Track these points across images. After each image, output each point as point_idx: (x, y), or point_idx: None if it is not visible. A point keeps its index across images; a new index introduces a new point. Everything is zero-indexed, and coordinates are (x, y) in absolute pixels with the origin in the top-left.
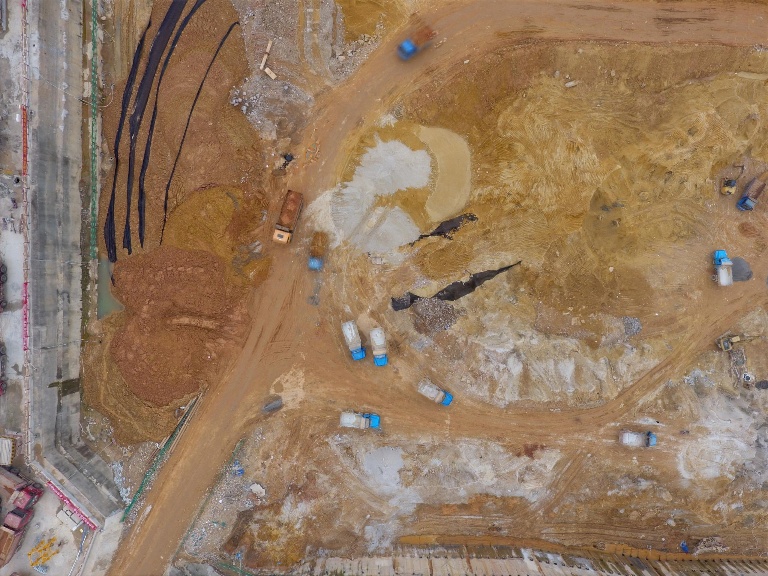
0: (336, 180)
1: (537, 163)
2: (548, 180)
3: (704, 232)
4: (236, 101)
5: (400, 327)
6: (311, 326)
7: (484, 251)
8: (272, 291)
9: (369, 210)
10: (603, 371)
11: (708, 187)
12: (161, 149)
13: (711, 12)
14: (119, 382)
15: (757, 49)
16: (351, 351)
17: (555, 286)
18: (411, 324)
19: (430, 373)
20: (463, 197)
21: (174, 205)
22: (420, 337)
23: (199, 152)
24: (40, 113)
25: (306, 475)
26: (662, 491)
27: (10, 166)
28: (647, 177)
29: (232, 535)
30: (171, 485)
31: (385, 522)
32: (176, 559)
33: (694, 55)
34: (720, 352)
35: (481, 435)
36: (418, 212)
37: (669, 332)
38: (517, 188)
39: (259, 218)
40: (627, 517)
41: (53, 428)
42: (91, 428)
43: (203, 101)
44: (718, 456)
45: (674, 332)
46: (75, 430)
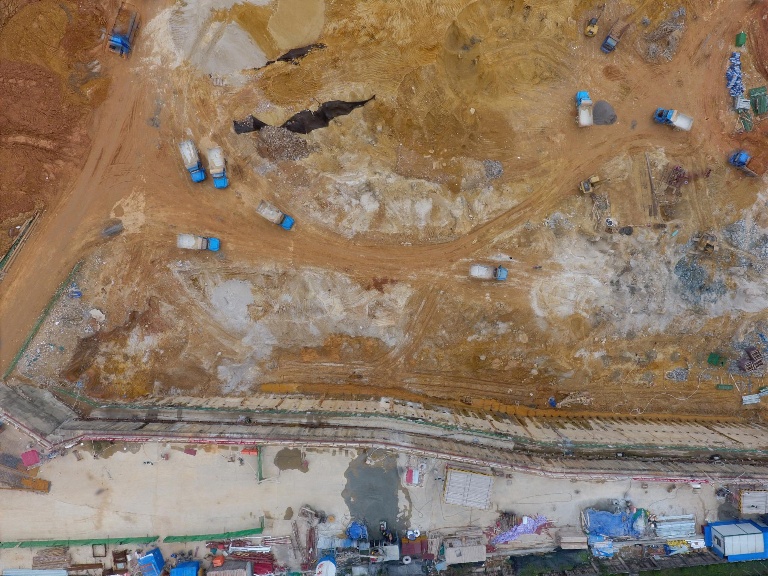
0: None
1: None
2: (403, 13)
3: (568, 75)
4: None
5: (243, 151)
6: (152, 148)
7: (333, 80)
8: (112, 112)
9: (206, 25)
10: (459, 210)
11: (571, 28)
12: None
13: None
14: None
15: None
16: (188, 170)
17: (415, 127)
18: (254, 148)
19: (273, 198)
20: (315, 28)
21: (6, 16)
22: (263, 162)
23: None
24: None
25: (148, 302)
26: (520, 333)
27: None
28: (507, 14)
29: (76, 366)
30: (5, 305)
31: (239, 363)
32: (9, 378)
33: None
34: (583, 197)
35: (327, 265)
36: (260, 33)
37: (531, 176)
38: (371, 21)
39: (97, 36)
40: (490, 366)
41: None
42: None
43: None
44: (572, 293)
45: (537, 176)
46: None
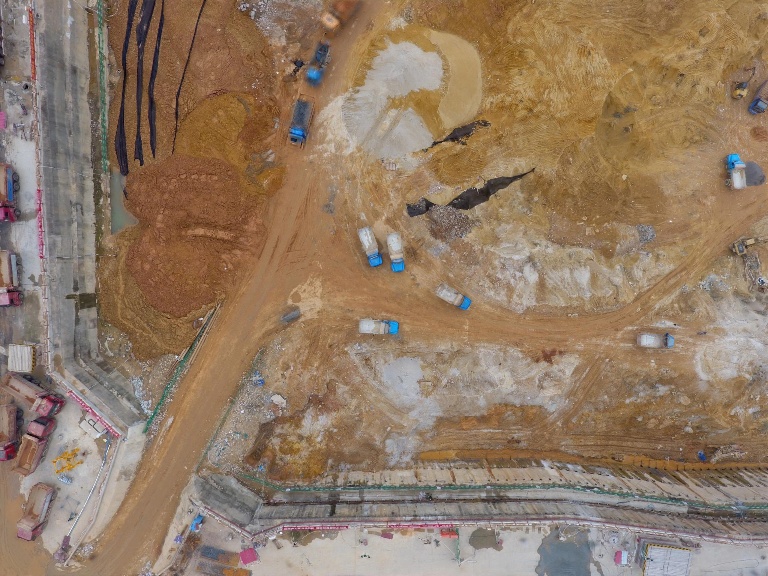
0: (347, 85)
1: (548, 69)
2: (560, 85)
3: (716, 137)
4: (244, 6)
5: (416, 233)
6: (327, 235)
7: (498, 157)
8: (286, 200)
9: (382, 113)
10: (619, 277)
11: (719, 91)
12: (169, 57)
13: None
14: (136, 294)
15: None
16: (368, 256)
17: (569, 196)
18: (427, 230)
19: (447, 279)
20: (475, 104)
21: (185, 112)
22: (436, 243)
23: (208, 58)
24: (46, 17)
25: (326, 385)
26: (680, 396)
27: (18, 72)
28: (658, 81)
29: (254, 449)
30: (192, 396)
31: (405, 435)
32: (200, 469)
33: None
34: (734, 257)
35: (500, 341)
36: (431, 116)
37: (683, 239)
38: (529, 94)
39: (271, 126)
40: (645, 426)
41: (72, 340)
42: (109, 344)
43: (210, 7)
44: (735, 357)
45: (688, 239)
46: (93, 345)
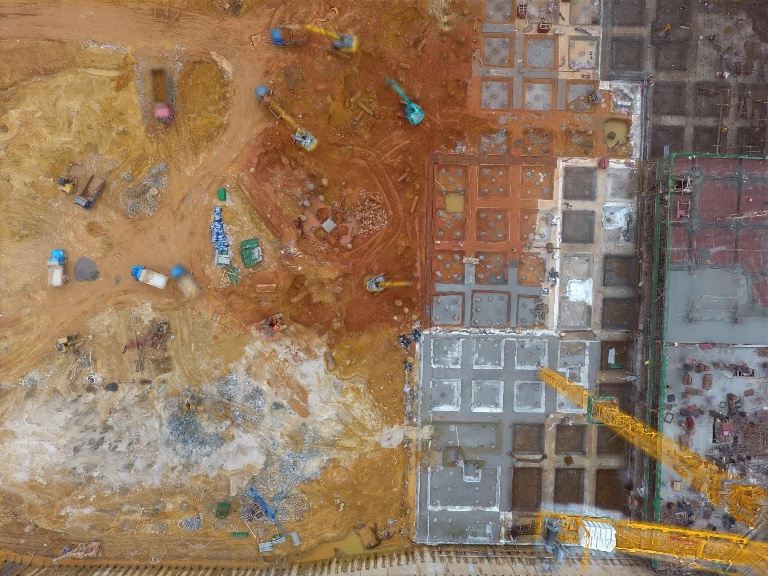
0: None
1: None
2: None
3: (50, 231)
4: None
5: None
6: None
7: None
8: None
9: None
10: None
11: (48, 186)
12: None
13: (32, 7)
14: None
15: (90, 45)
16: None
17: None
18: None
19: None
20: None
21: None
22: None
23: None
24: None
25: None
26: None
27: None
28: None
29: None
30: None
31: None
32: None
33: (22, 51)
34: (67, 354)
35: None
36: None
37: (14, 334)
38: None
39: None
40: None
41: None
42: None
43: None
44: (27, 460)
45: (20, 334)
46: None
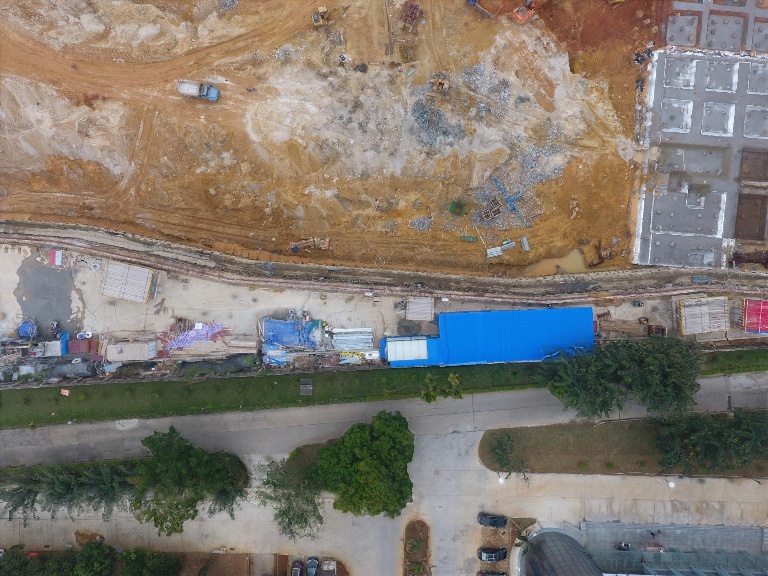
0: None
1: None
2: None
3: None
4: None
5: None
6: None
7: None
8: None
9: None
10: (183, 34)
11: None
12: None
13: None
14: None
15: None
16: None
17: None
18: None
19: None
20: None
21: None
22: None
23: None
24: None
25: None
26: (242, 163)
27: None
28: None
29: None
30: None
31: None
32: None
33: None
34: (319, 32)
35: (32, 75)
36: None
37: (267, 9)
38: None
39: None
40: (222, 202)
41: None
42: None
43: None
44: (288, 119)
45: (272, 9)
46: None
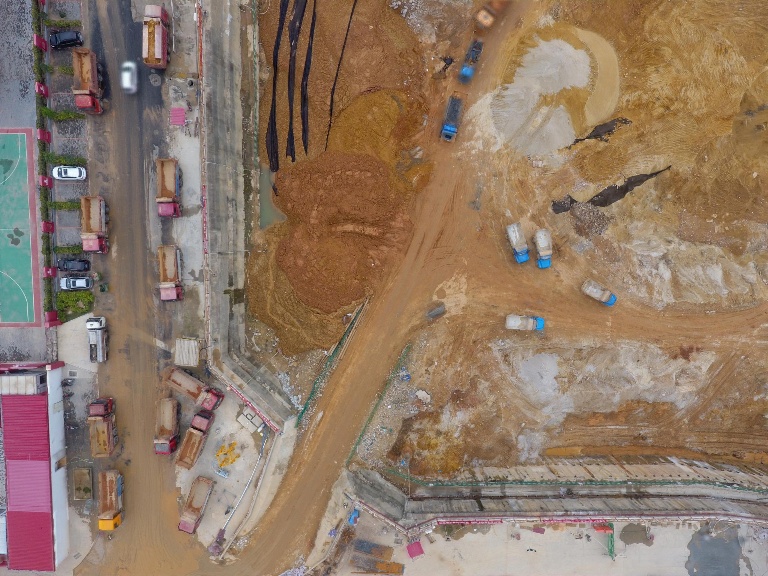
0: (496, 82)
1: (685, 67)
2: (697, 83)
3: None
4: (396, 4)
5: (561, 230)
6: (473, 231)
7: (638, 154)
8: (433, 197)
9: (533, 110)
10: (753, 275)
11: None
12: (323, 54)
13: None
14: (287, 290)
15: None
16: (517, 253)
17: (700, 193)
18: (572, 227)
19: (591, 275)
20: (613, 102)
21: (340, 109)
22: (581, 240)
23: (362, 55)
24: (212, 14)
25: (469, 381)
26: None
27: (183, 69)
28: None
29: (394, 444)
30: (341, 391)
31: (537, 431)
32: (350, 463)
33: None
34: None
35: (640, 337)
36: (578, 113)
37: None
38: (666, 92)
39: (420, 123)
40: None
41: (227, 335)
42: (256, 339)
43: (362, 5)
44: None
45: None
46: (242, 340)
